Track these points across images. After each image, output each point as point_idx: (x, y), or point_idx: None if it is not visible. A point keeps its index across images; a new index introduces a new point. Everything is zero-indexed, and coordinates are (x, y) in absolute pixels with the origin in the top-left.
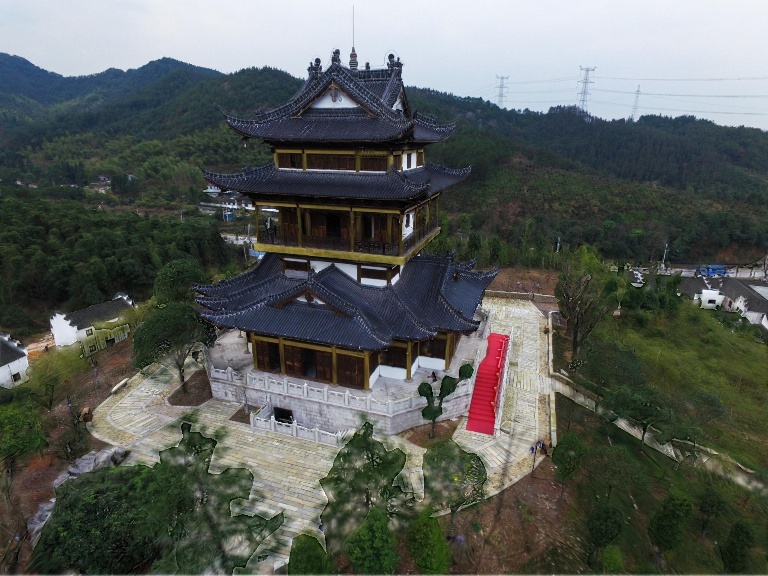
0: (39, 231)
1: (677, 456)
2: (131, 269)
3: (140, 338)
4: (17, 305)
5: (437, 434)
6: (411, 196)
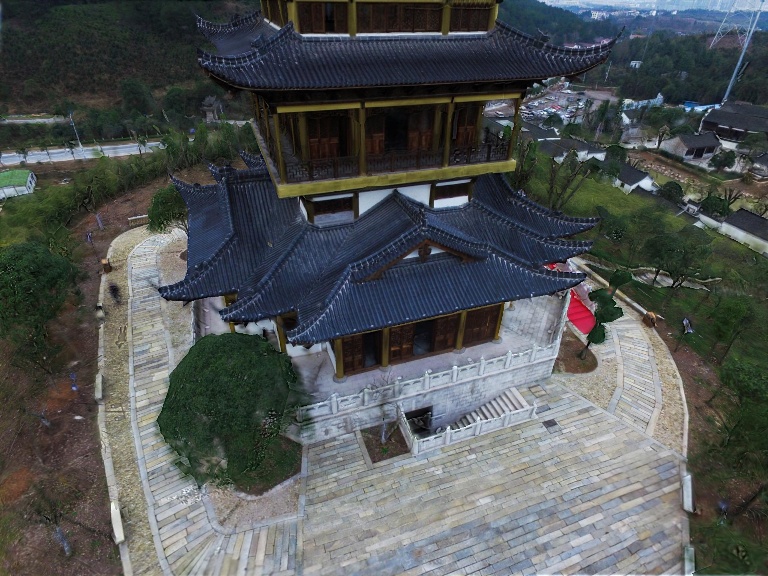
0: None
1: (643, 282)
2: None
3: (209, 432)
4: None
5: None
6: (575, 70)
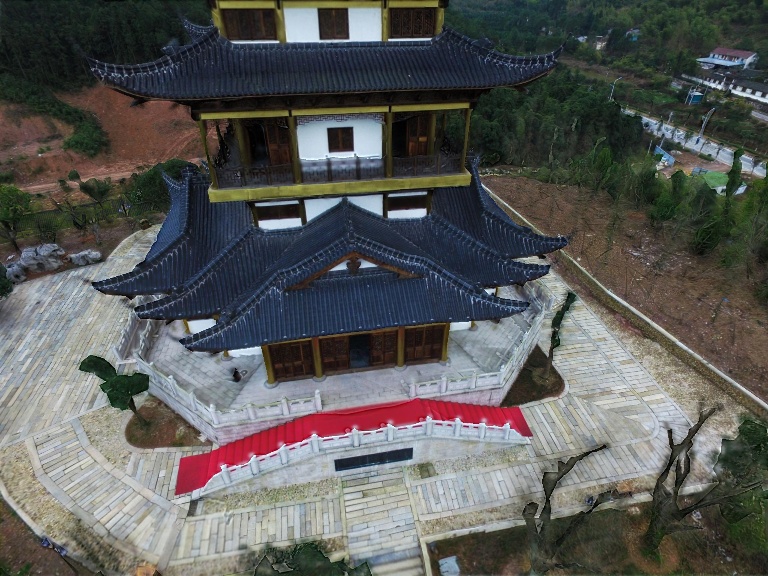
0: None
1: None
2: (489, 132)
3: None
4: None
5: (151, 429)
6: None
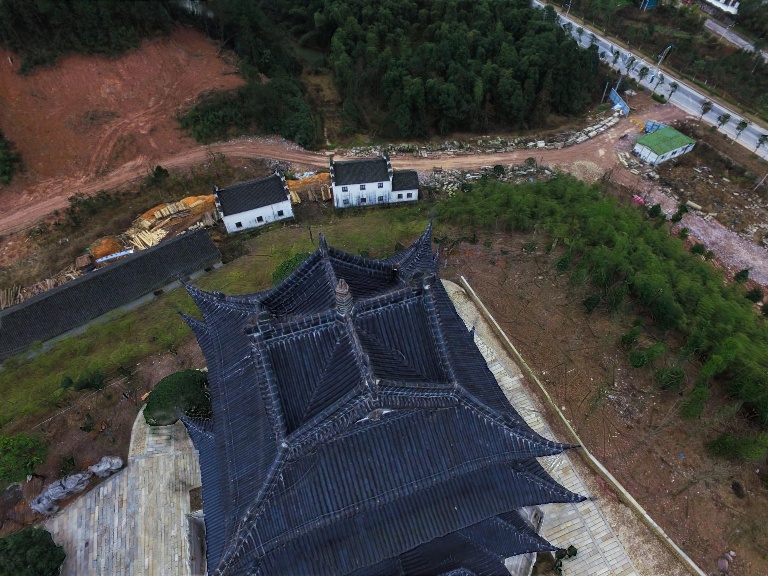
0: (412, 9)
1: None
2: (445, 99)
3: None
4: (364, 93)
5: None
6: None
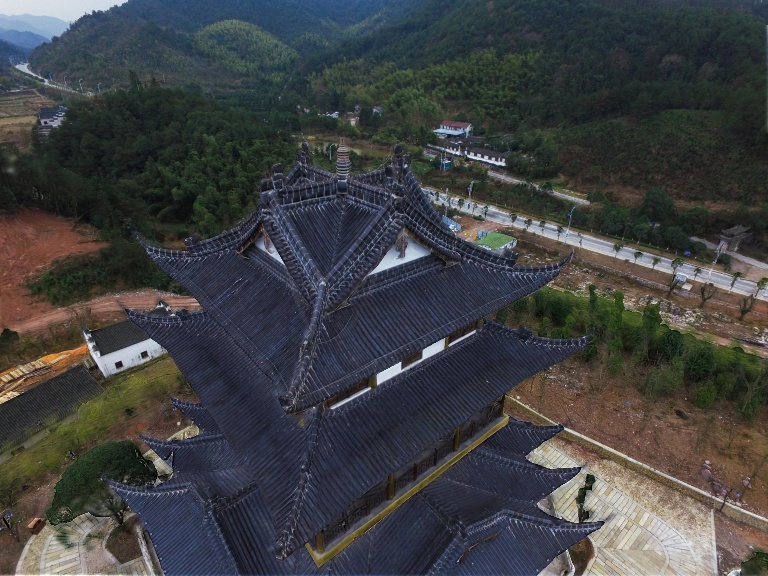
0: None
1: None
2: None
3: None
4: None
5: None
6: None
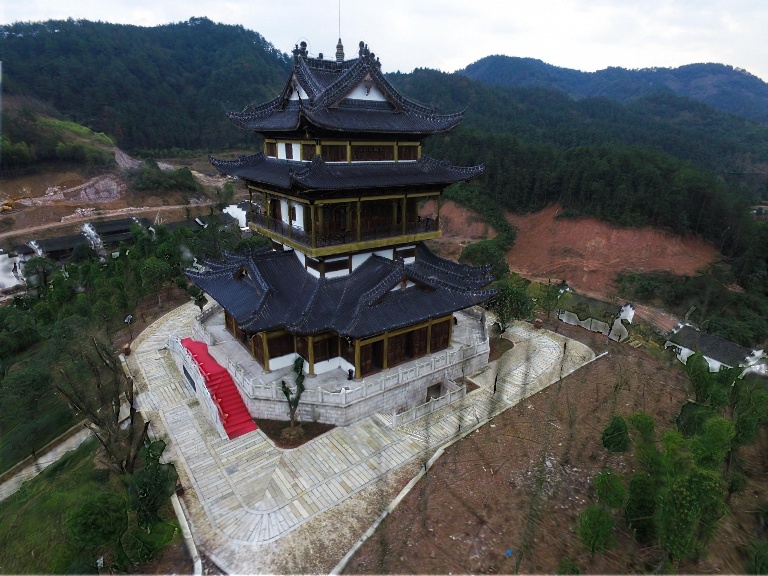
0: None
1: None
2: None
3: None
4: None
5: None
6: None
